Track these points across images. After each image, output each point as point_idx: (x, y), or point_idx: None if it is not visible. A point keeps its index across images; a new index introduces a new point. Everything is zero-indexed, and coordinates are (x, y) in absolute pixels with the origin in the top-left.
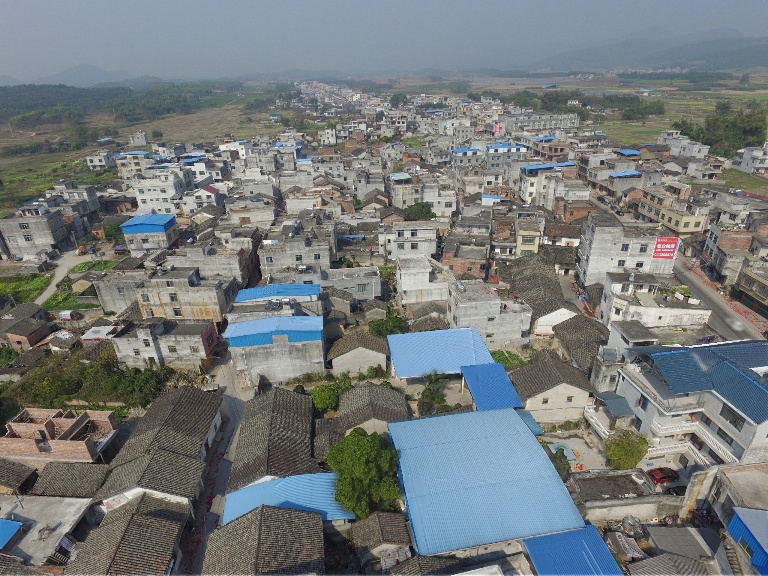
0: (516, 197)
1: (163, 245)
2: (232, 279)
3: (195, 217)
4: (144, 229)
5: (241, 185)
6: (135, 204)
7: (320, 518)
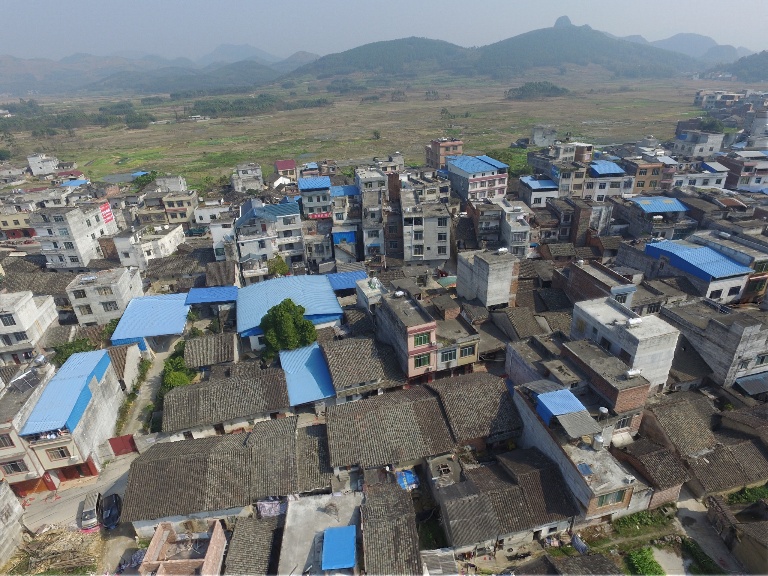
0: None
1: None
2: None
3: None
4: None
5: None
6: None
7: None
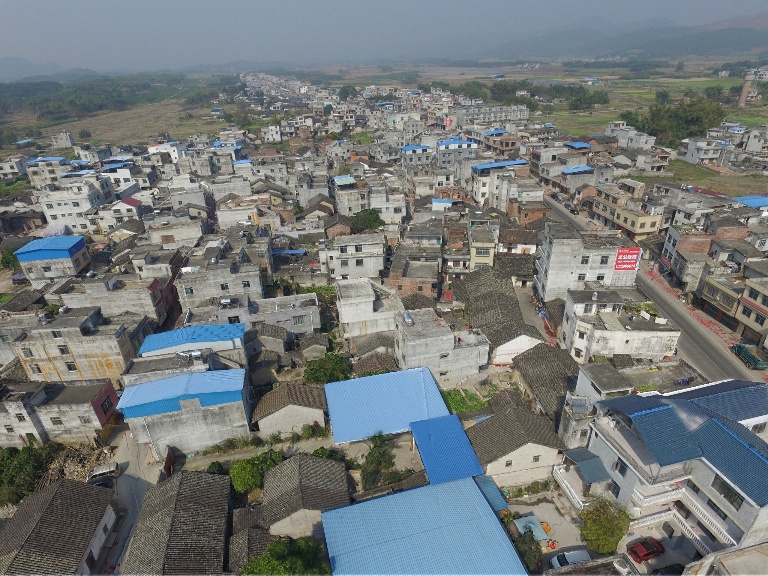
0: (469, 197)
1: (70, 272)
2: (142, 319)
3: (113, 234)
4: (44, 255)
5: (168, 195)
6: None
7: None
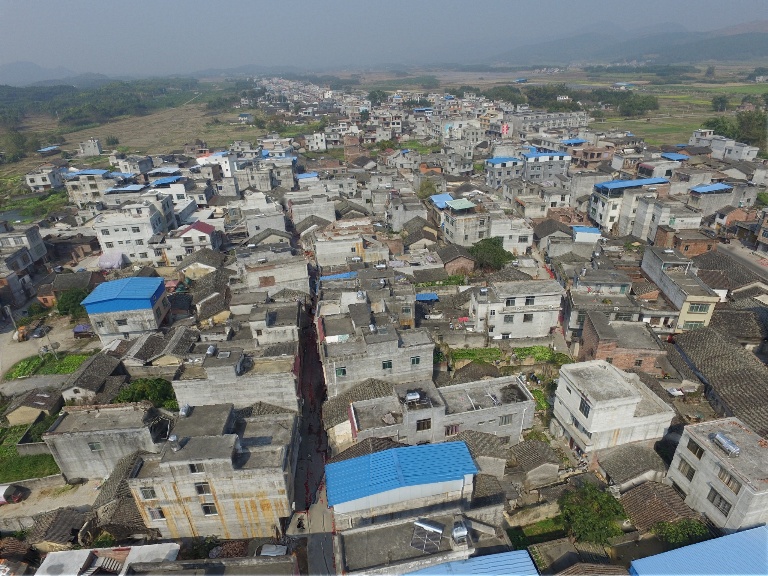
0: None
1: (149, 326)
2: (293, 422)
3: (186, 269)
4: (120, 306)
5: (242, 218)
6: (96, 245)
7: None
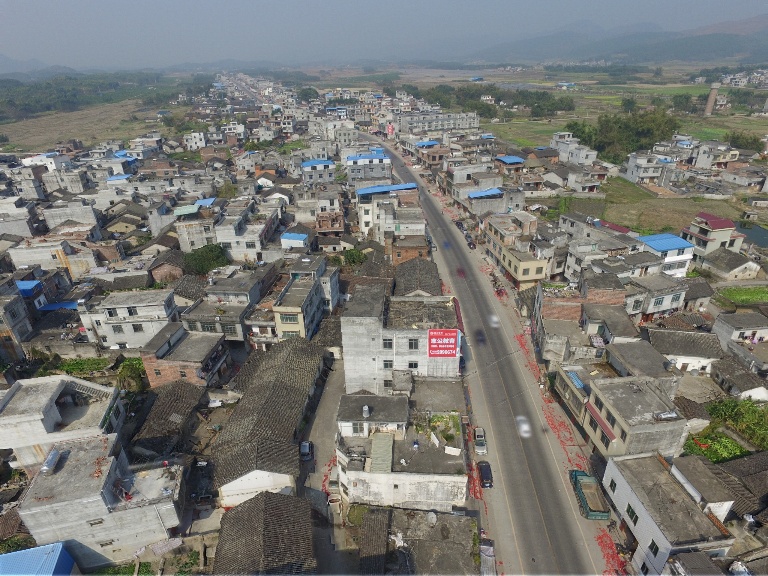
0: None
1: None
2: None
3: None
4: None
5: None
6: None
7: None
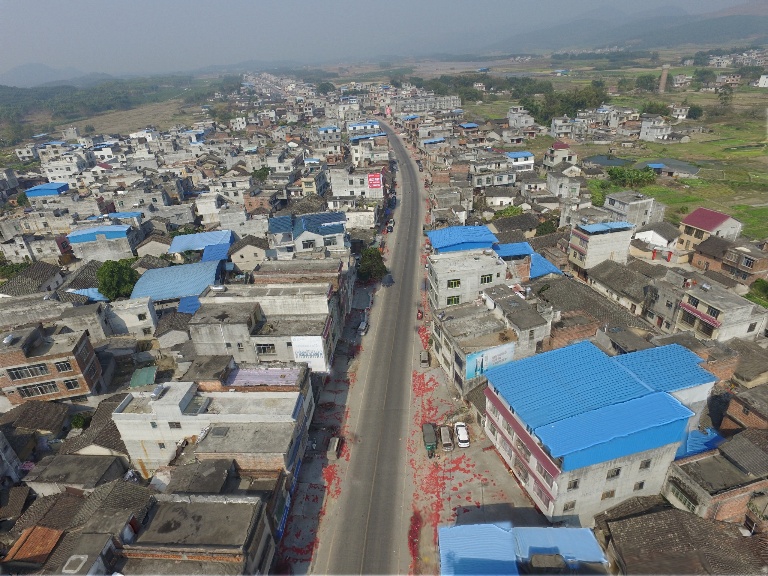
0: None
1: None
2: (91, 215)
3: None
4: (42, 193)
5: None
6: None
7: (87, 298)
